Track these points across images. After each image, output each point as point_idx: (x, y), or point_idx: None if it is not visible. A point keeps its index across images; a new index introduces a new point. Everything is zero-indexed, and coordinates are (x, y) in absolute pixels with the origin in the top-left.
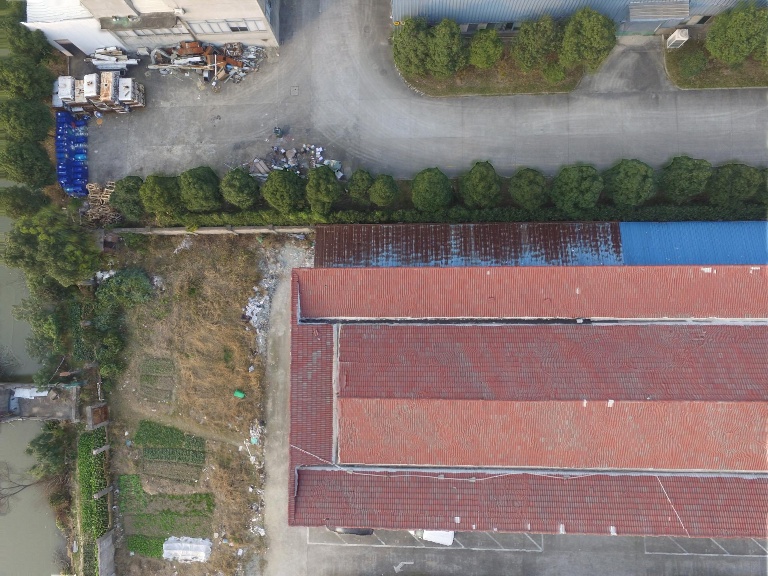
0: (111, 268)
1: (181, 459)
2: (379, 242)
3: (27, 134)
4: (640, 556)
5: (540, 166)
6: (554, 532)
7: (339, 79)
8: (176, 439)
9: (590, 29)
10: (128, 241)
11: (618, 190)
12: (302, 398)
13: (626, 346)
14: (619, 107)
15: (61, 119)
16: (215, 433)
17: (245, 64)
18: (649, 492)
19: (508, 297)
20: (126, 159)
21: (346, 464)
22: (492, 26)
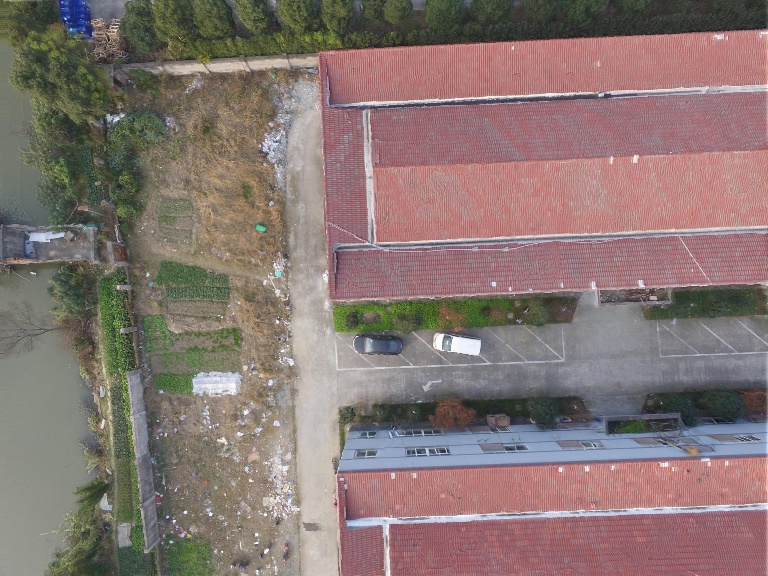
0: (121, 111)
1: (205, 296)
2: None
3: None
4: (655, 360)
5: None
6: (586, 288)
7: None
8: (199, 277)
9: None
10: (138, 79)
11: None
12: (336, 179)
13: (645, 118)
14: None
15: None
16: (238, 269)
17: None
18: (672, 250)
19: (532, 73)
20: None
21: (382, 244)
22: None
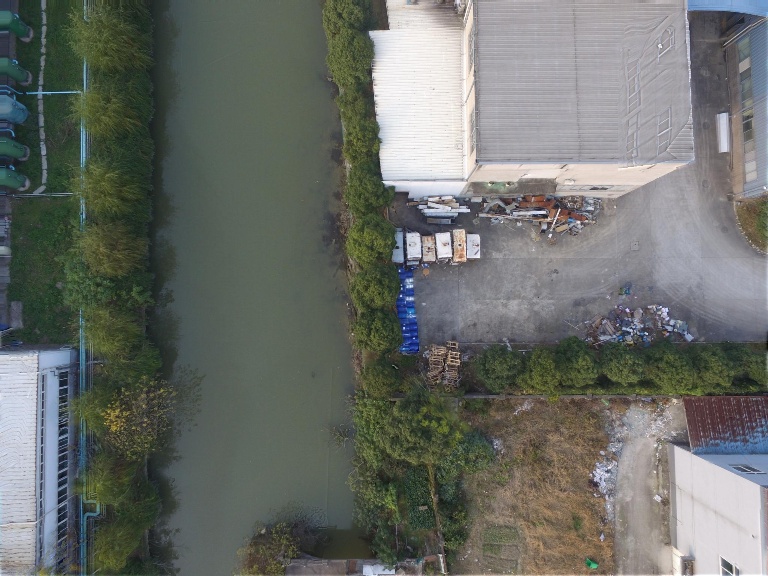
0: None
1: None
2: (751, 416)
3: (390, 303)
4: None
5: None
6: None
7: (680, 235)
8: None
9: None
10: (474, 406)
11: None
12: None
13: None
14: None
15: (401, 276)
16: None
17: None
18: None
19: None
20: (458, 313)
21: None
22: None
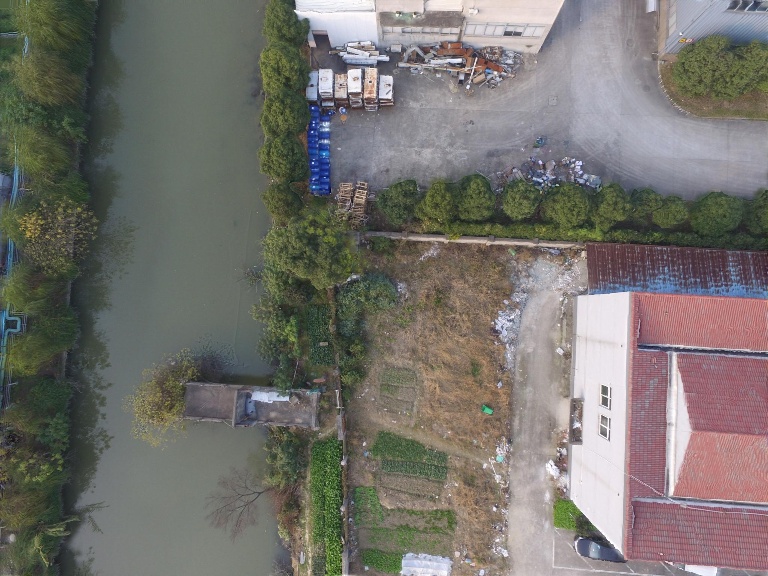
0: None
1: (422, 474)
2: (654, 264)
3: (294, 128)
4: None
5: None
6: None
7: (600, 92)
8: (418, 453)
9: None
10: (378, 245)
11: None
12: (640, 427)
13: None
14: None
15: (314, 113)
16: (459, 449)
17: (503, 69)
18: None
19: None
20: (371, 159)
21: (677, 497)
22: None
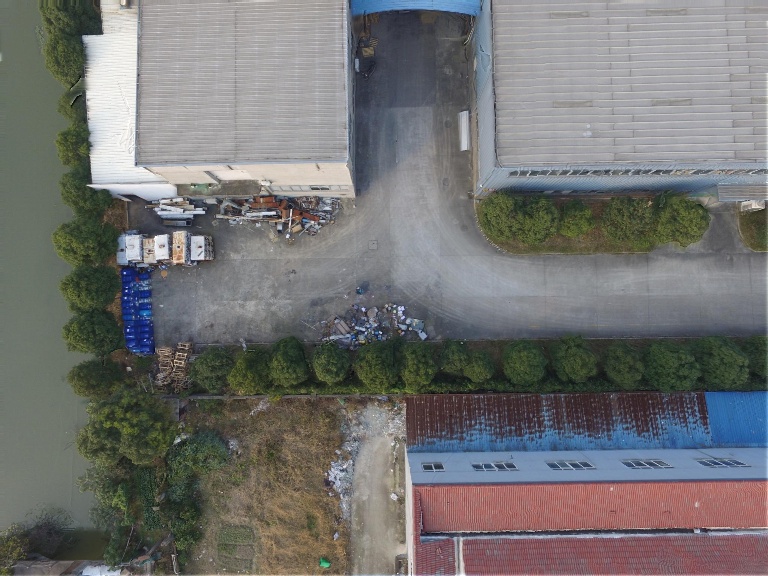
0: (182, 431)
1: None
2: (471, 414)
3: (97, 305)
4: None
5: (622, 327)
6: None
7: (419, 234)
8: None
9: (689, 220)
10: (203, 407)
11: (711, 372)
12: None
13: None
14: (696, 268)
15: (127, 278)
16: None
17: (321, 217)
18: None
19: (629, 511)
20: (195, 315)
21: None
22: (577, 191)
